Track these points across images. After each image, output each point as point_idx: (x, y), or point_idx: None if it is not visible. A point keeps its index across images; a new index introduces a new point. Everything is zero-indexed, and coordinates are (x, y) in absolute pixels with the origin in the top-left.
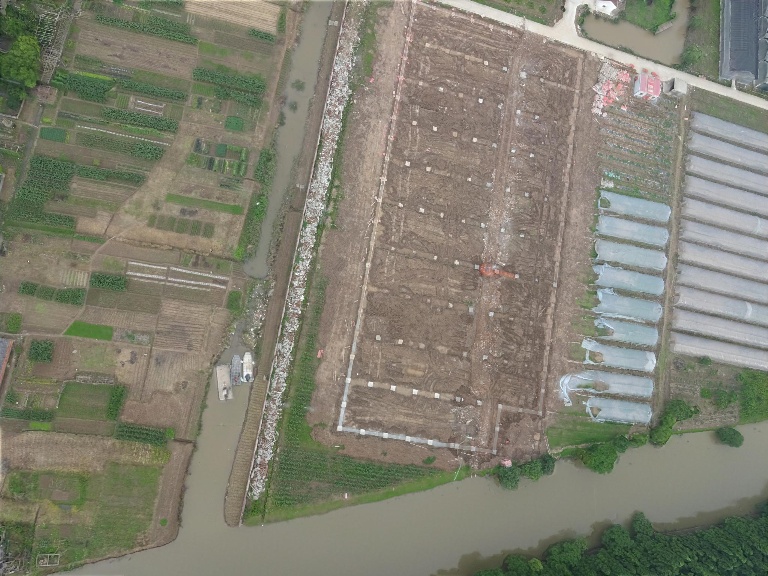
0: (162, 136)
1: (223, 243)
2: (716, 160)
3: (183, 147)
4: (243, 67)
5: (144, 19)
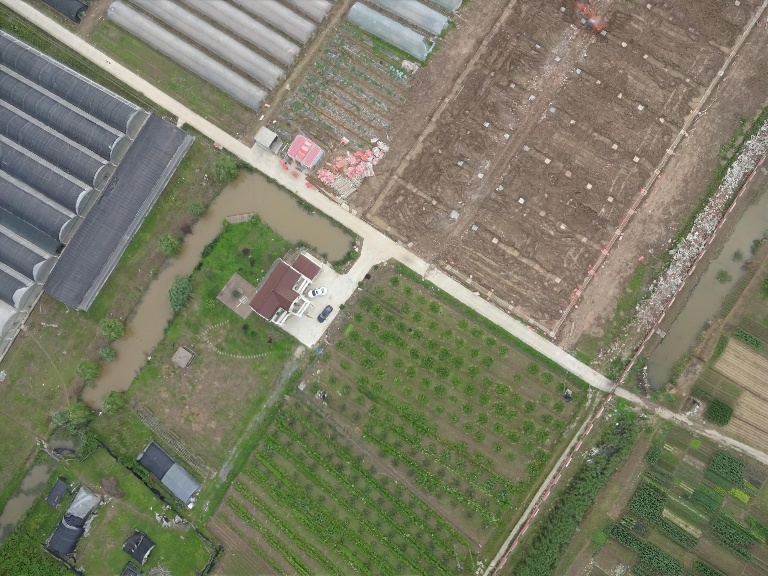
0: None
1: None
2: (253, 48)
3: None
4: None
5: None
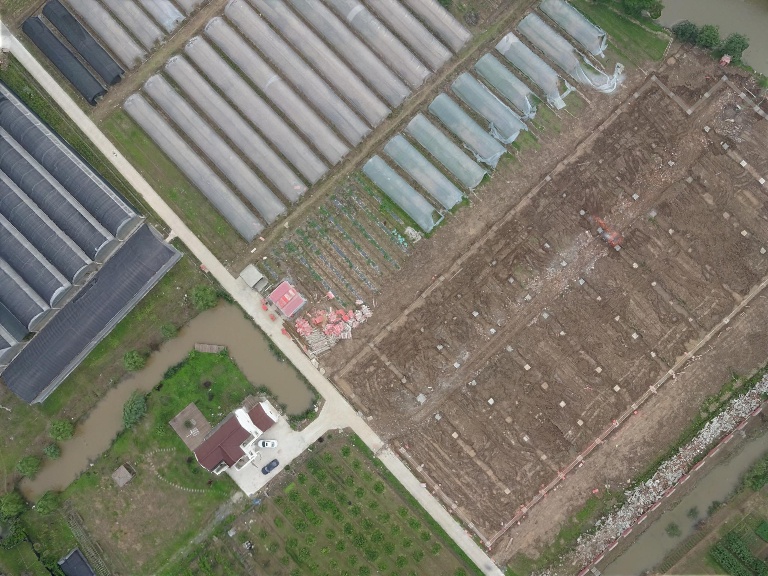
0: None
1: None
2: (261, 176)
3: None
4: None
5: None
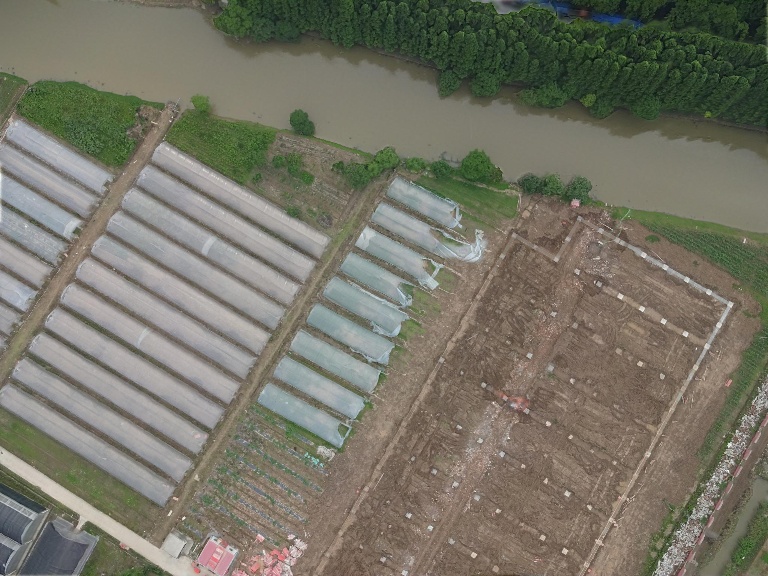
0: None
1: None
2: (158, 434)
3: None
4: None
5: None
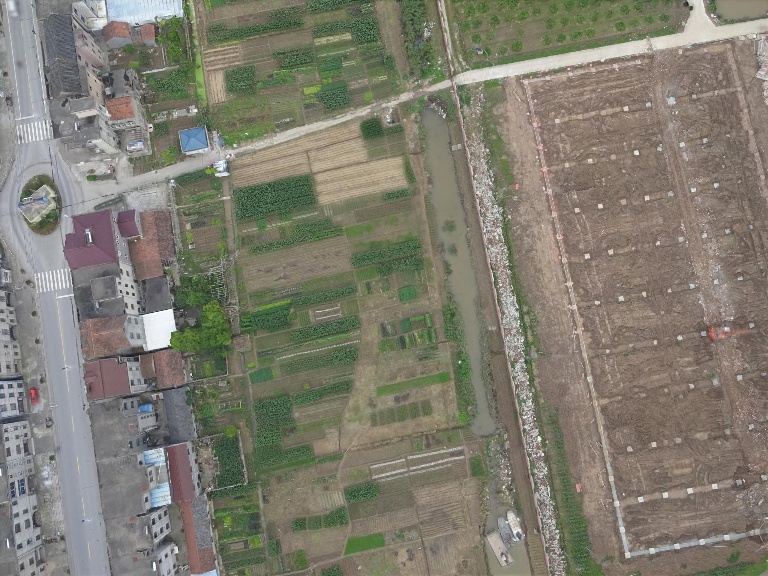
0: (350, 336)
1: (444, 415)
2: None
3: (372, 338)
4: (392, 234)
5: (289, 231)
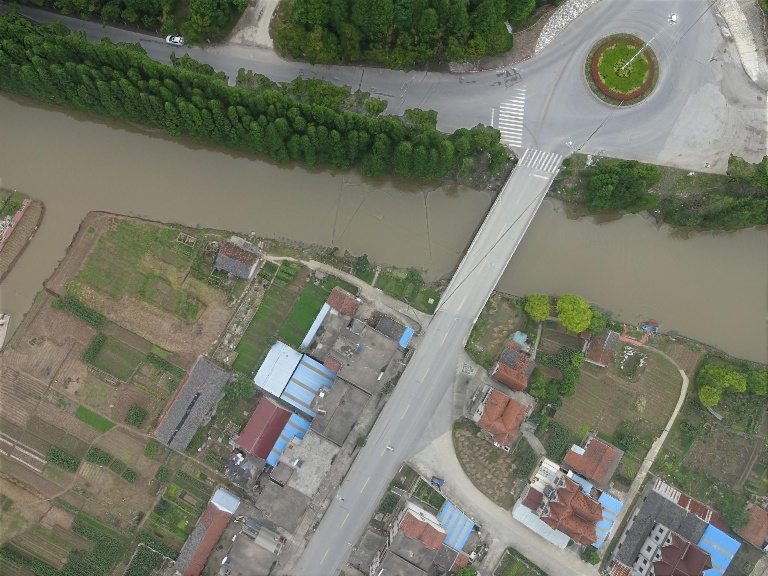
0: None
1: None
2: None
3: None
4: None
5: None
